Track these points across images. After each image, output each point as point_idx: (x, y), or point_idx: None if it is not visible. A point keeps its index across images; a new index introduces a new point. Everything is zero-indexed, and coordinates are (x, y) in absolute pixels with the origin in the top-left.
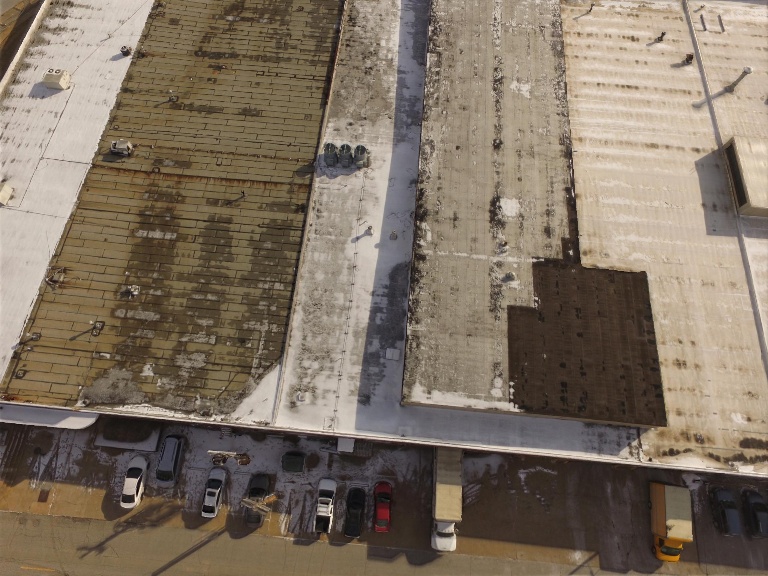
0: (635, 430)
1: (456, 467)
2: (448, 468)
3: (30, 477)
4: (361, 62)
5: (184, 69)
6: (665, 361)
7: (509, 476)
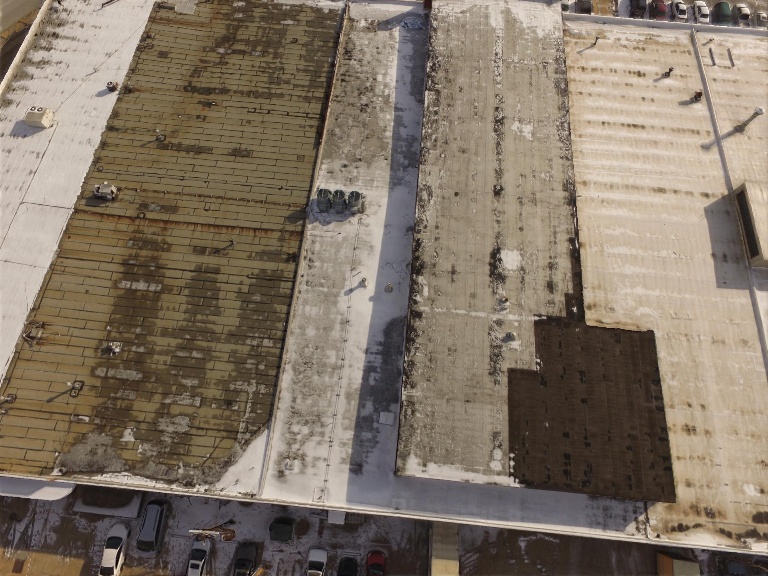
0: (642, 503)
1: (453, 540)
2: (444, 541)
3: (4, 545)
4: (357, 98)
5: (172, 106)
6: (673, 426)
7: (509, 544)
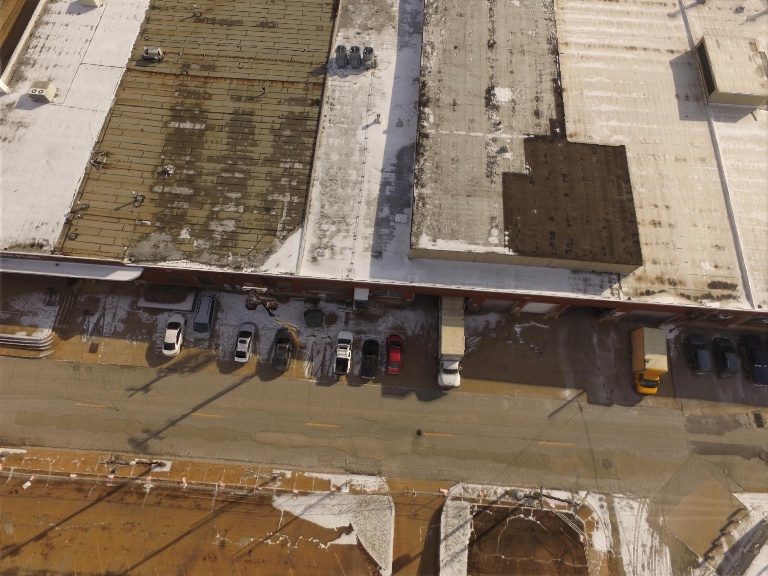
0: (616, 276)
1: (459, 313)
2: (452, 314)
3: (81, 333)
4: None
5: None
6: (642, 221)
7: (506, 330)
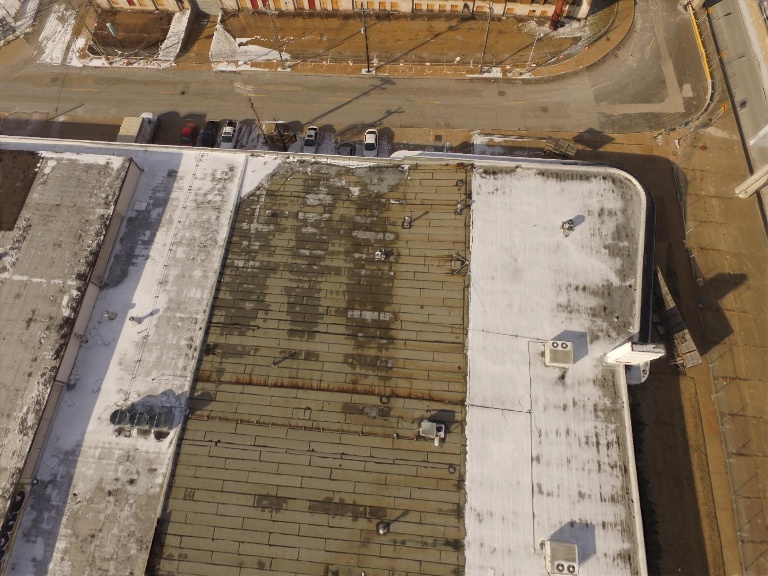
0: None
1: None
2: None
3: (452, 148)
4: None
5: None
6: None
7: None
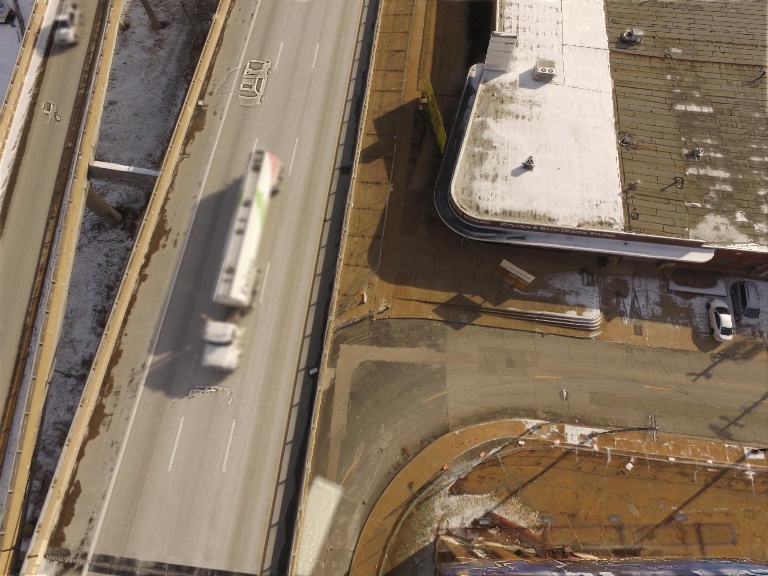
0: None
1: None
2: None
3: (620, 315)
4: None
5: None
6: None
7: None
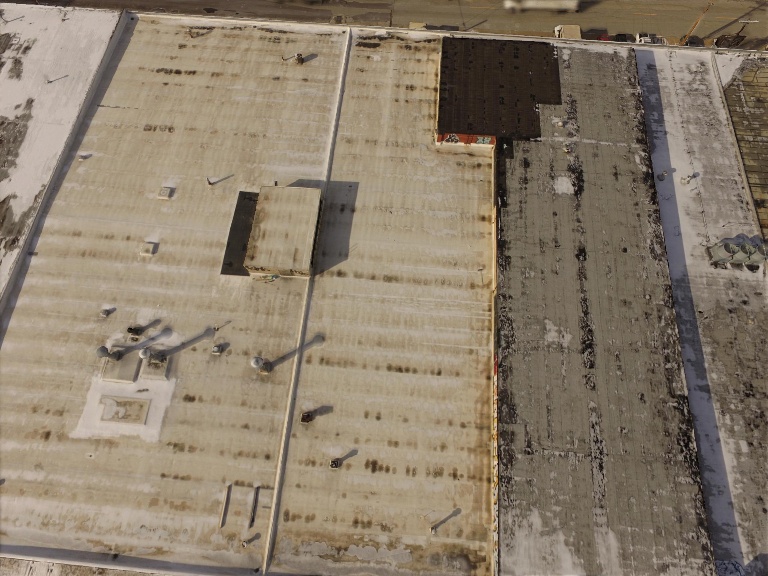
0: None
1: None
2: None
3: None
4: (764, 406)
5: None
6: (422, 89)
7: None
